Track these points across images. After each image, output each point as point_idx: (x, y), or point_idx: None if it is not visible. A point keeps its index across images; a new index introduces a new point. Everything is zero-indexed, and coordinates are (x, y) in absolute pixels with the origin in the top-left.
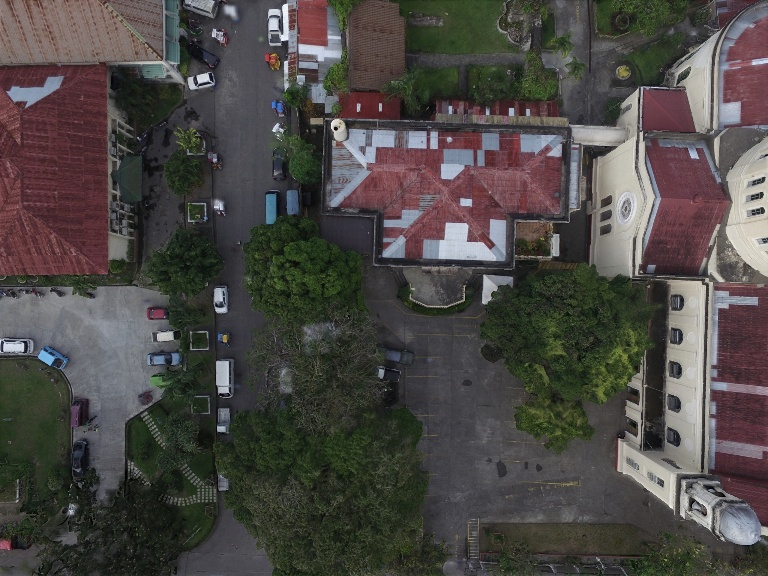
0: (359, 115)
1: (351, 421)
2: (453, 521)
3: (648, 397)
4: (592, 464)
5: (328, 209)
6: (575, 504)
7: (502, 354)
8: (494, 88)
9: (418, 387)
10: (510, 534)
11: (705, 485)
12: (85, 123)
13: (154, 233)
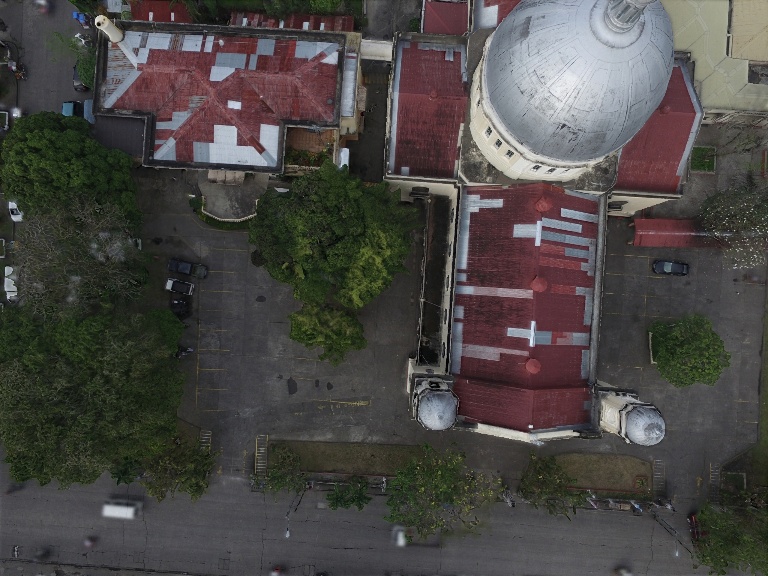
0: None
1: (85, 308)
2: (242, 437)
3: (426, 312)
4: (383, 384)
5: (102, 110)
6: (365, 424)
7: (263, 256)
8: (286, 0)
9: (212, 302)
10: (298, 452)
11: (431, 381)
12: None
13: None
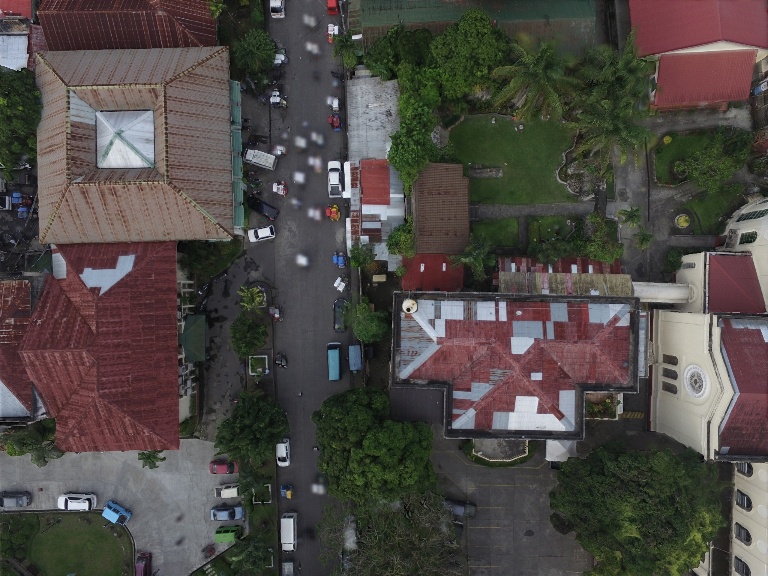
0: (423, 275)
1: None
2: None
3: (714, 558)
4: None
5: (397, 380)
6: None
7: (574, 529)
8: (557, 247)
9: (480, 538)
10: None
11: None
12: (156, 301)
13: (215, 384)
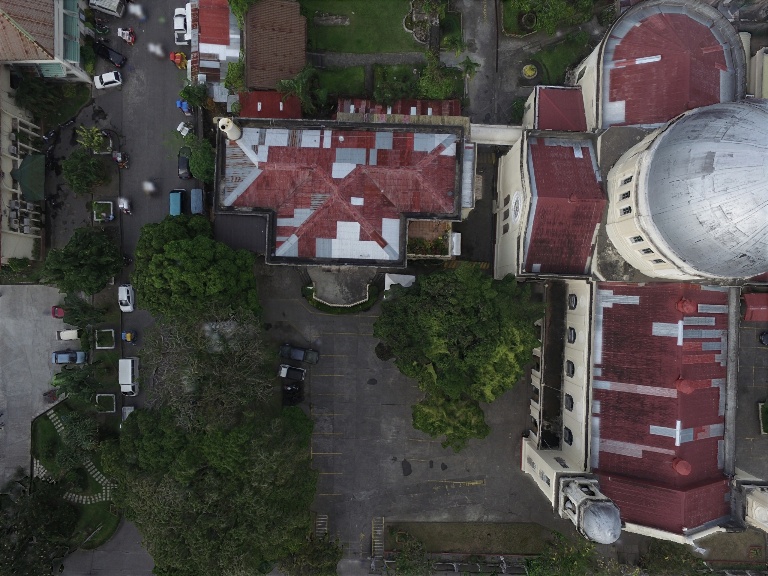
0: (260, 114)
1: (229, 419)
2: (358, 520)
3: (546, 396)
4: (497, 463)
5: (222, 208)
6: (480, 503)
7: (392, 353)
8: (395, 87)
9: (323, 386)
10: (415, 533)
11: (580, 484)
12: None
13: (61, 232)
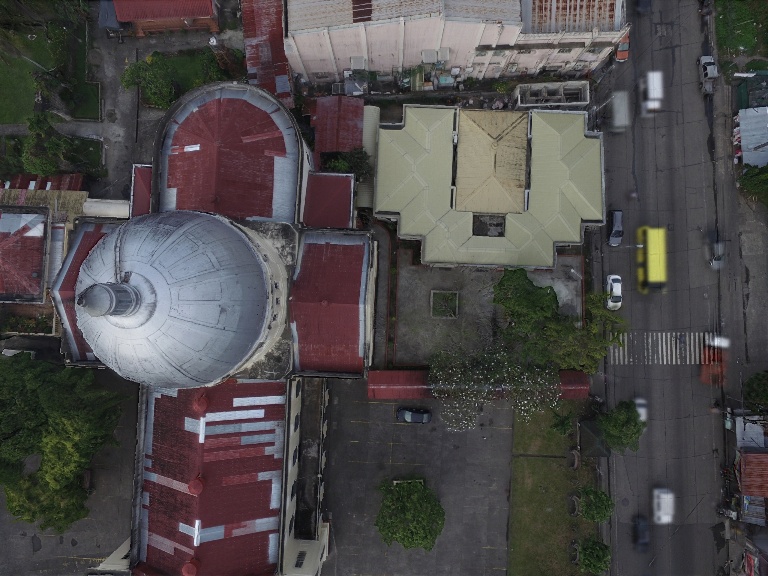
0: None
1: None
2: None
3: None
4: None
5: None
6: None
7: None
8: (9, 162)
9: None
10: None
11: None
12: None
13: None
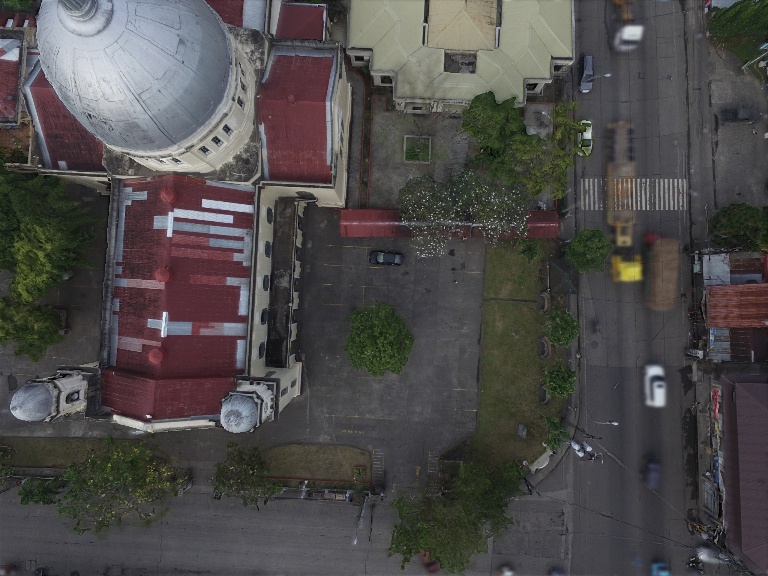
0: None
1: None
2: None
3: None
4: None
5: None
6: None
7: None
8: None
9: None
10: (19, 447)
11: (62, 373)
12: None
13: None
